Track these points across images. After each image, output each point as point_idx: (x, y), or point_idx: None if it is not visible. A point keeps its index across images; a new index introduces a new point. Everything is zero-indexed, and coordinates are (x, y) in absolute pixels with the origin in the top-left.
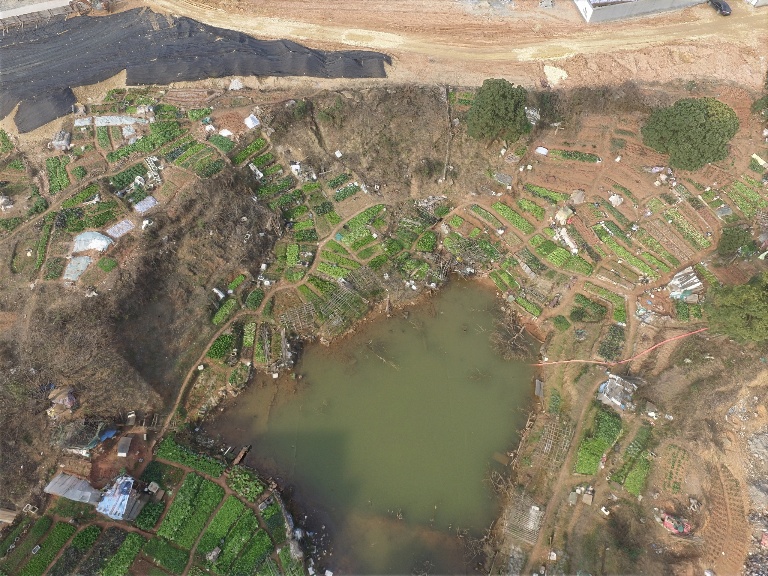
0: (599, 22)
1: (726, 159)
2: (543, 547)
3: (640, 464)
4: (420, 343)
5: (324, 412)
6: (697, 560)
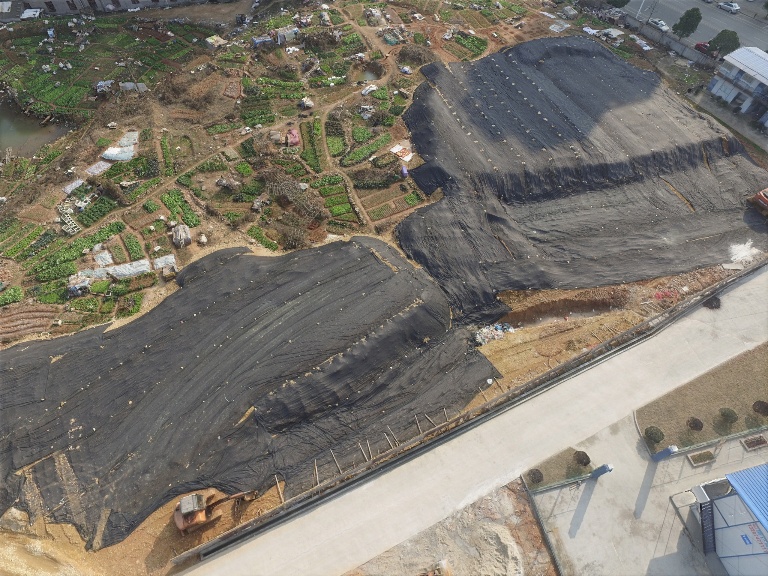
0: None
1: None
2: None
3: None
4: None
5: None
6: None
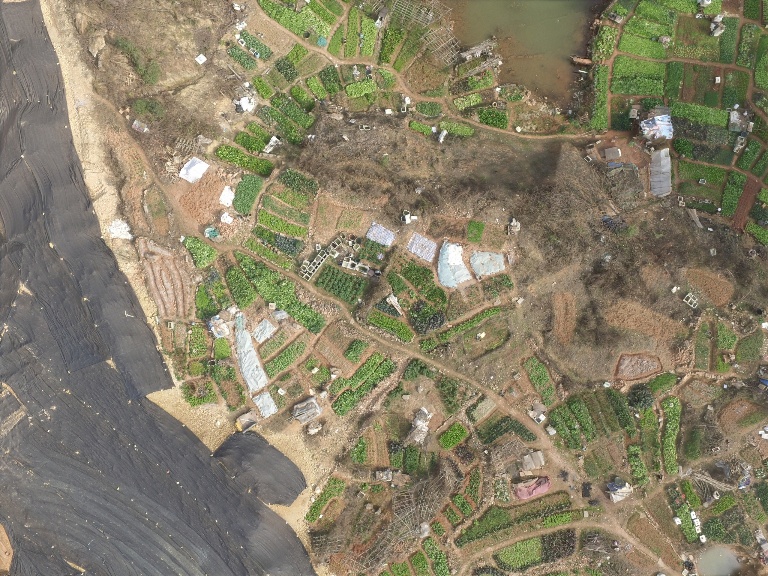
0: None
1: None
2: None
3: None
4: None
5: (521, 3)
6: None
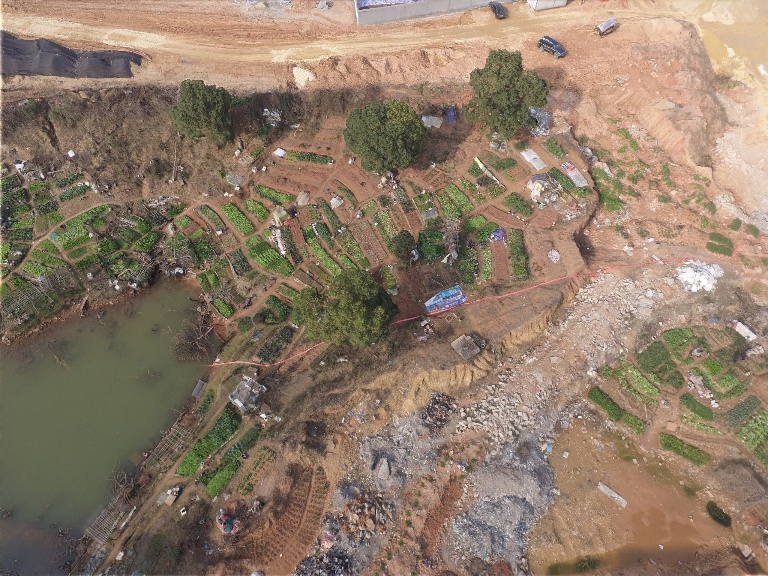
0: (371, 24)
1: (449, 162)
2: (121, 547)
3: (230, 465)
4: (104, 343)
5: None
6: (239, 561)
